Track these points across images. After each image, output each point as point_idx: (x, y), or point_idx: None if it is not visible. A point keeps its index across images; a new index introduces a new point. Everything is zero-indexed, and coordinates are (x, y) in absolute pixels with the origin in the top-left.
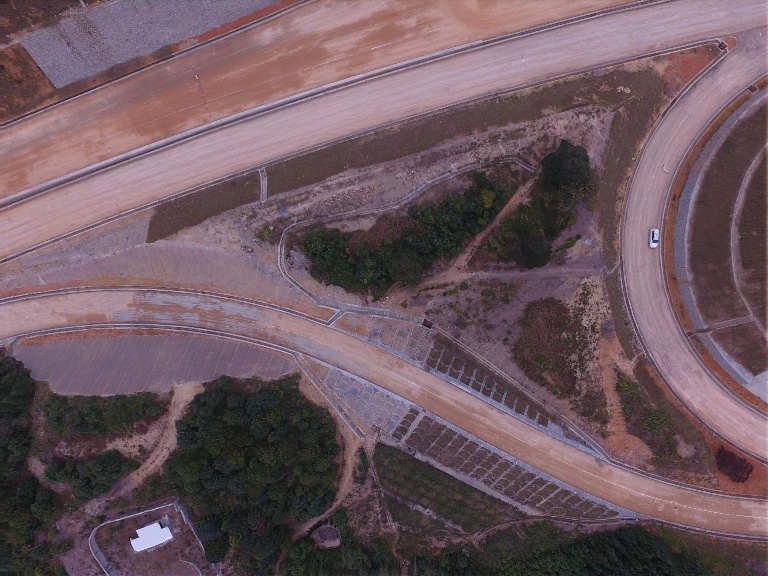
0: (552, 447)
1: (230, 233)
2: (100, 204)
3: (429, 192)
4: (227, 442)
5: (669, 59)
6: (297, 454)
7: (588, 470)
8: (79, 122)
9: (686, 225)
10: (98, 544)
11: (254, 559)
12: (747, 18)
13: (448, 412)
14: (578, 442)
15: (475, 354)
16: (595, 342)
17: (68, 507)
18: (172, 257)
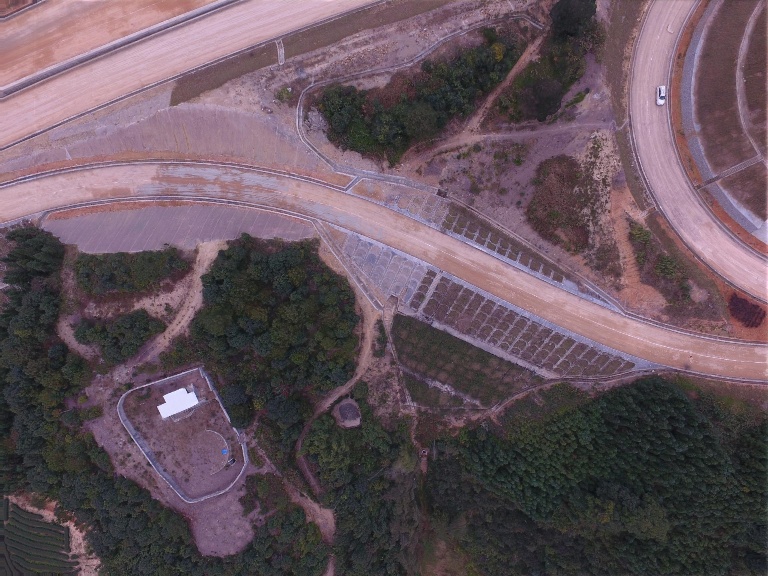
0: (567, 302)
1: (250, 95)
2: (123, 80)
3: (441, 48)
4: (251, 296)
5: None
6: (318, 317)
7: (603, 323)
8: (102, 0)
9: (692, 78)
10: (126, 413)
11: (277, 430)
12: None
13: (465, 272)
14: (593, 296)
15: (489, 219)
16: (607, 195)
17: (97, 374)
18: (194, 122)
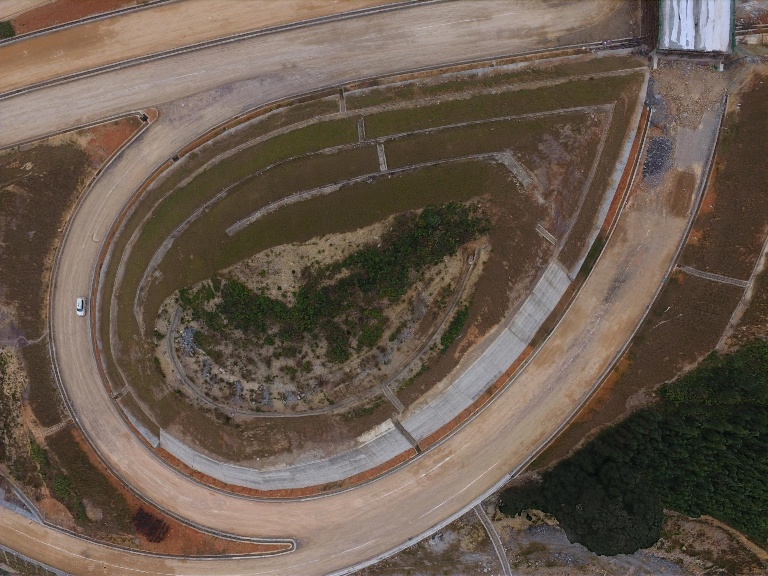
0: None
1: None
2: None
3: None
4: None
5: (92, 132)
6: None
7: (25, 532)
8: None
9: (97, 295)
10: None
11: None
12: (170, 89)
13: None
14: (17, 505)
15: None
16: (17, 410)
17: None
18: None
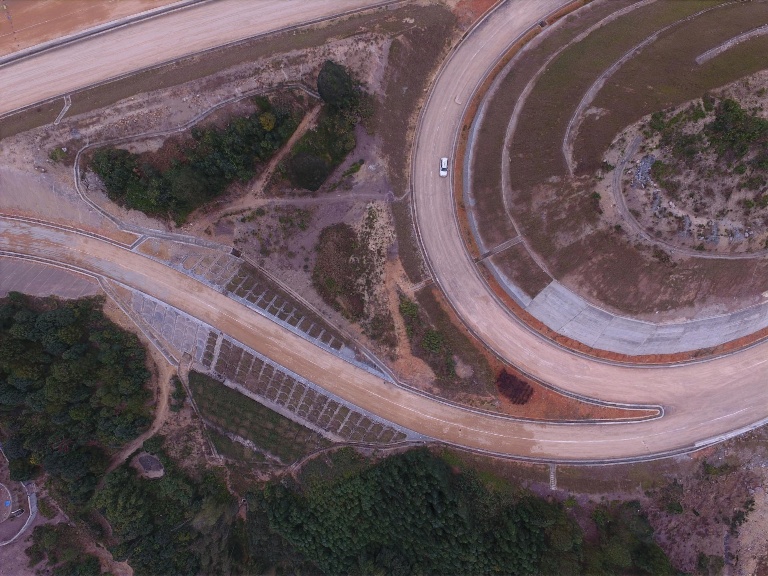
0: (343, 370)
1: (24, 153)
2: None
3: (213, 115)
4: (16, 355)
5: None
6: (97, 374)
7: (377, 393)
8: None
9: (470, 152)
10: None
11: (66, 482)
12: None
13: (245, 335)
14: (368, 365)
15: (278, 282)
16: (381, 266)
17: None
18: None
